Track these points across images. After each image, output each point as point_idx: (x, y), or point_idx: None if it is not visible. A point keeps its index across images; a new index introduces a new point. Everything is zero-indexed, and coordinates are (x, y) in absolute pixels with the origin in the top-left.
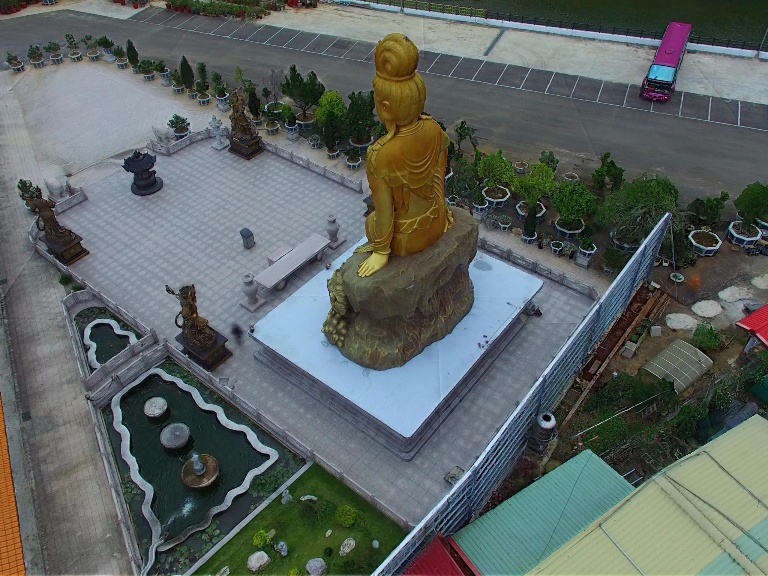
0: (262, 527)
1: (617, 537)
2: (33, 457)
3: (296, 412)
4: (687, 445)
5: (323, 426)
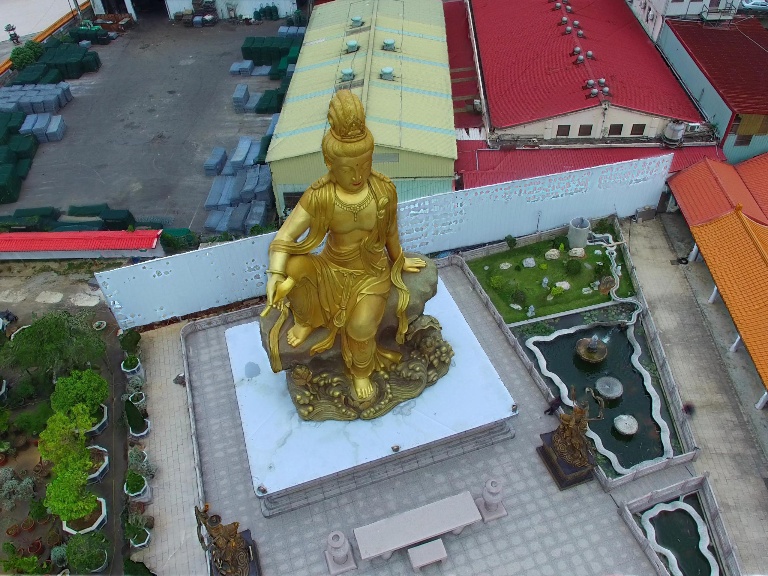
0: (554, 306)
1: (398, 142)
2: (749, 434)
3: (499, 365)
4: (282, 218)
5: (482, 345)
